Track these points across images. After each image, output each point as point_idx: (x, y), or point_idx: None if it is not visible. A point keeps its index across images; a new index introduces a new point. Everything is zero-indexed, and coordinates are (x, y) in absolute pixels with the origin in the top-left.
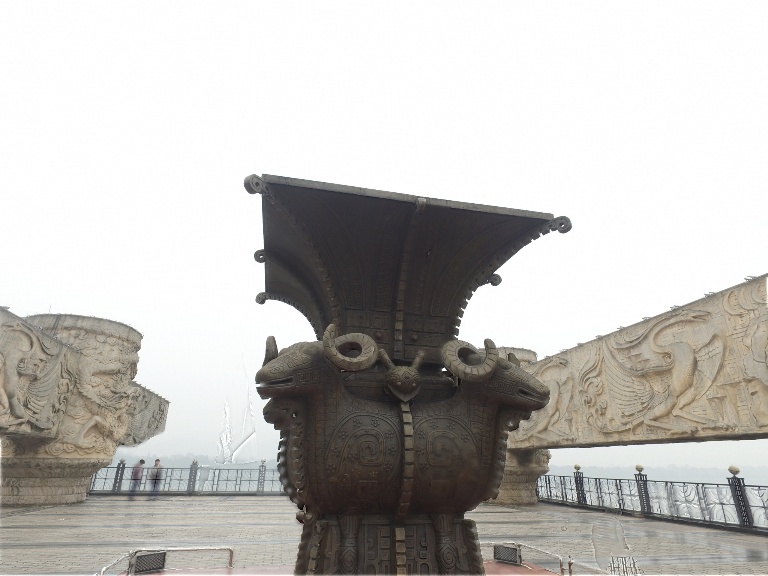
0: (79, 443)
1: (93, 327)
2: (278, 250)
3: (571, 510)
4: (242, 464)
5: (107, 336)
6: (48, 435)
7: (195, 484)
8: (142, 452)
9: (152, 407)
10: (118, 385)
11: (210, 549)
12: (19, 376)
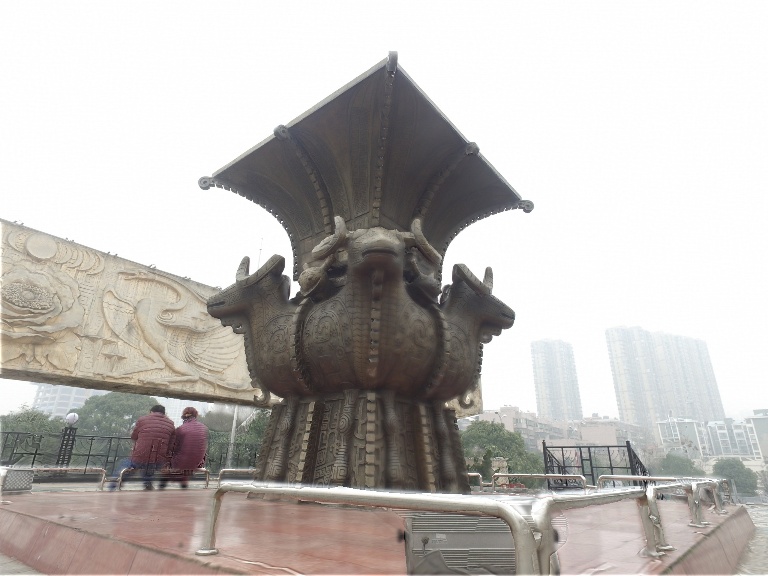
0: None
1: None
2: (466, 165)
3: None
4: None
5: None
6: None
7: None
8: None
9: None
10: None
11: (267, 489)
12: None
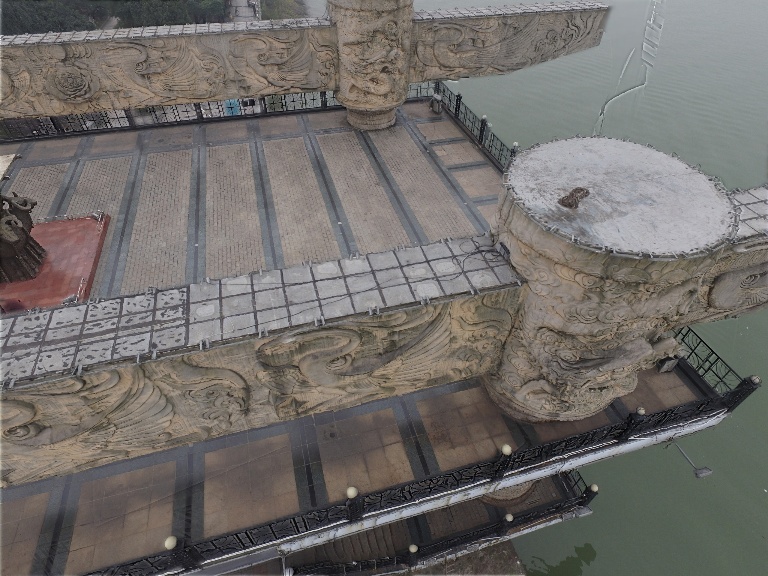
0: (346, 97)
1: (335, 2)
2: None
3: (441, 445)
4: (508, 138)
5: (345, 9)
6: (326, 90)
7: (483, 138)
8: (524, 77)
9: (543, 27)
10: (366, 52)
11: None
12: (263, 65)
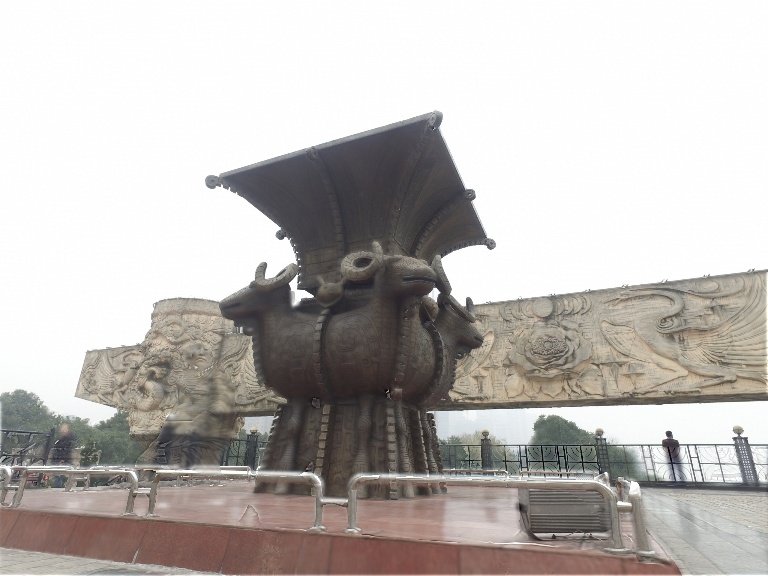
0: None
1: None
2: None
3: None
4: None
5: None
6: None
7: None
8: None
9: None
10: None
11: None
12: None
